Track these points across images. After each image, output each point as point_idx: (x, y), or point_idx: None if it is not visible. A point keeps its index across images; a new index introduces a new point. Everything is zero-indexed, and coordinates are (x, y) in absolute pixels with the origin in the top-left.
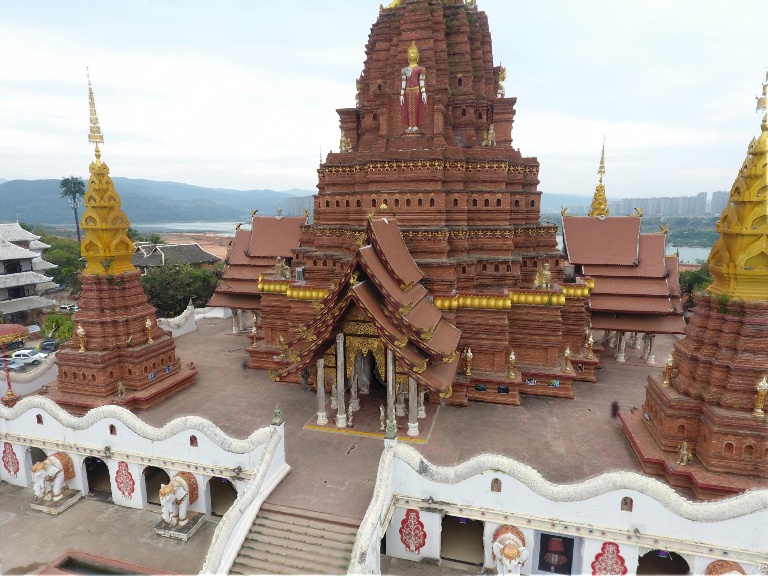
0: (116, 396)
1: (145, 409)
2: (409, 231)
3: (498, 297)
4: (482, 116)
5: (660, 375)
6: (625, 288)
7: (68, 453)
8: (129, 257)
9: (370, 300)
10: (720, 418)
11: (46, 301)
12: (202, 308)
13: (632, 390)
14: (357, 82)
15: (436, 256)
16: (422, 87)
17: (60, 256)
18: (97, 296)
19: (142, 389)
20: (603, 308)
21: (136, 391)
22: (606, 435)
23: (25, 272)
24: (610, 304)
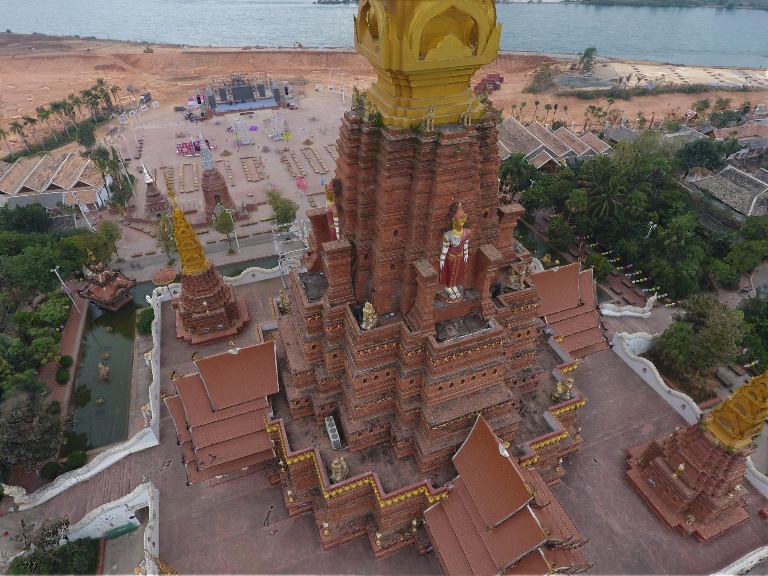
0: None
1: None
2: (484, 409)
3: None
4: None
5: (661, 459)
6: (574, 327)
7: None
8: None
9: (545, 552)
10: (718, 508)
11: None
12: (120, 446)
13: (594, 413)
14: (330, 193)
15: (502, 414)
16: (466, 249)
17: None
18: None
19: None
20: None
21: None
22: (625, 492)
23: None
24: (568, 345)
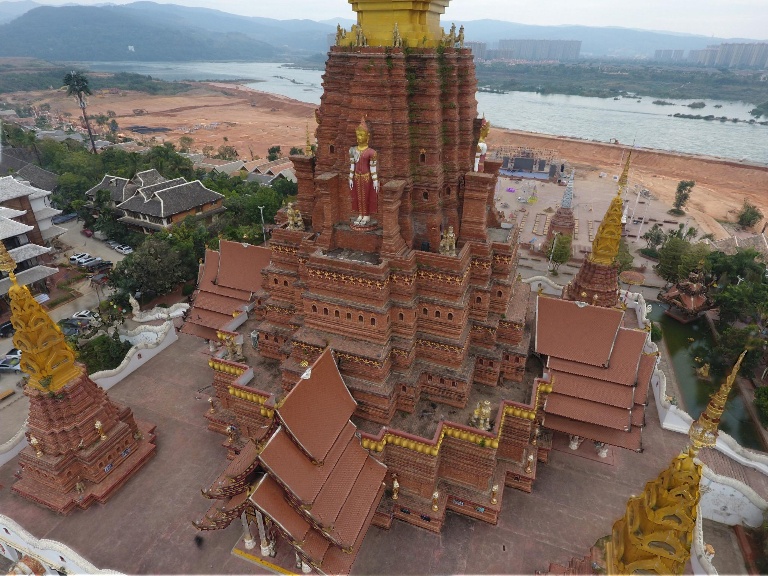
0: (76, 492)
1: (103, 502)
2: (346, 353)
3: (425, 445)
4: (451, 192)
5: None
6: (587, 391)
7: (35, 558)
8: (70, 365)
9: (274, 492)
10: None
11: (49, 270)
12: None
13: (561, 511)
14: (316, 115)
15: (373, 380)
16: (373, 174)
17: (70, 181)
18: (43, 410)
19: (100, 482)
20: (557, 413)
21: (95, 484)
22: None
23: (23, 246)
24: (566, 408)
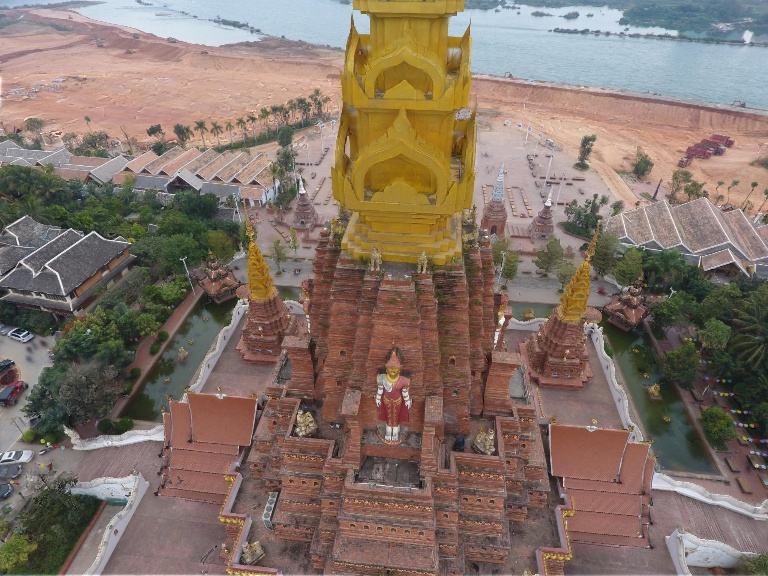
0: None
1: None
2: (397, 568)
3: None
4: (476, 374)
5: None
6: (601, 504)
7: None
8: None
9: None
10: None
11: None
12: (144, 430)
13: None
14: (304, 291)
15: None
16: (405, 397)
17: None
18: None
19: None
20: (578, 530)
21: None
22: None
23: None
24: (585, 523)
